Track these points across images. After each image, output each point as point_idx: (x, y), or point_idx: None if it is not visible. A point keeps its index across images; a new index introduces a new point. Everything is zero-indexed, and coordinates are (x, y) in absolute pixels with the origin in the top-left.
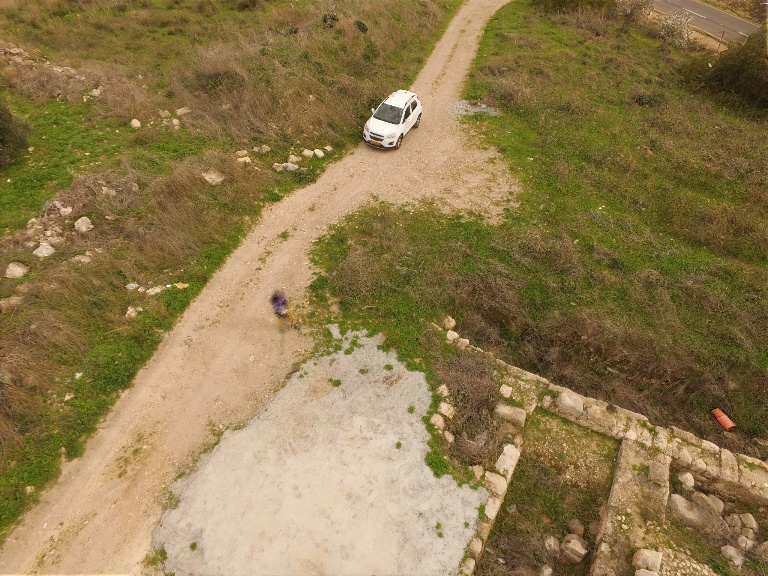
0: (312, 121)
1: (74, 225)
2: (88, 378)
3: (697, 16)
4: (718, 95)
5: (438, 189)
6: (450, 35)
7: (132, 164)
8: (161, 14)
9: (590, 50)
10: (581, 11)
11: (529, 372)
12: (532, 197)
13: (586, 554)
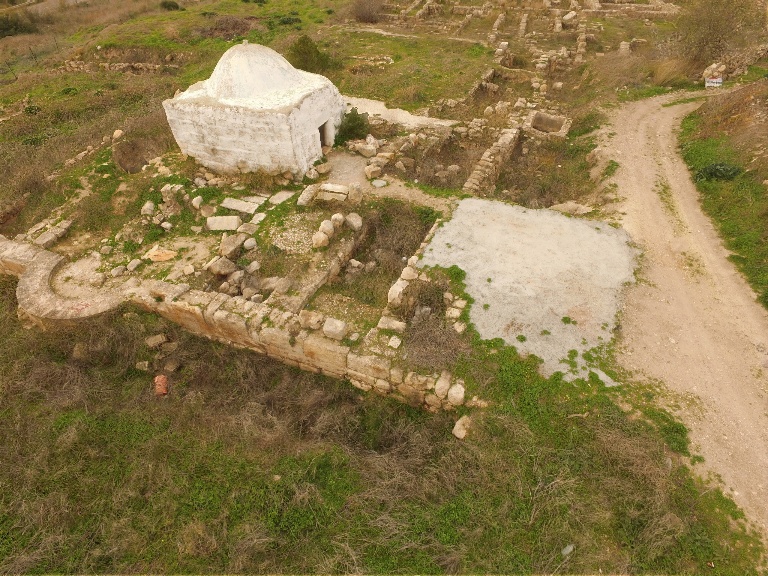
0: None
1: None
2: None
3: None
4: None
5: None
6: None
7: None
8: None
9: None
10: None
11: None
12: None
13: None
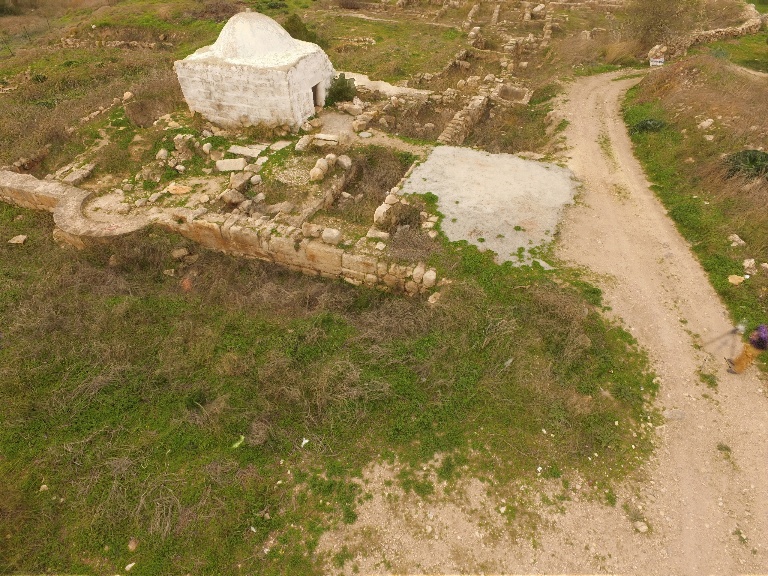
0: None
1: None
2: None
3: None
4: None
5: None
6: None
7: None
8: None
9: None
10: None
11: None
12: None
13: None
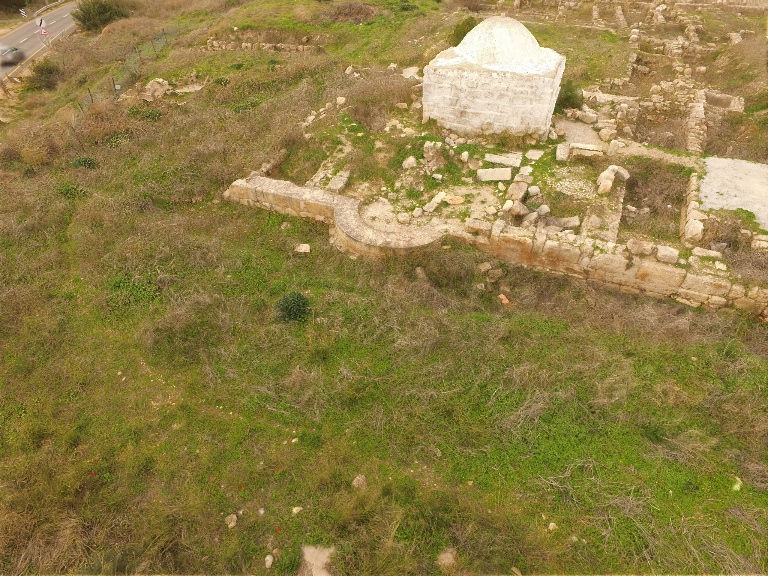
0: None
1: None
2: None
3: None
4: None
5: None
6: None
7: None
8: None
9: None
10: None
11: None
12: None
13: None
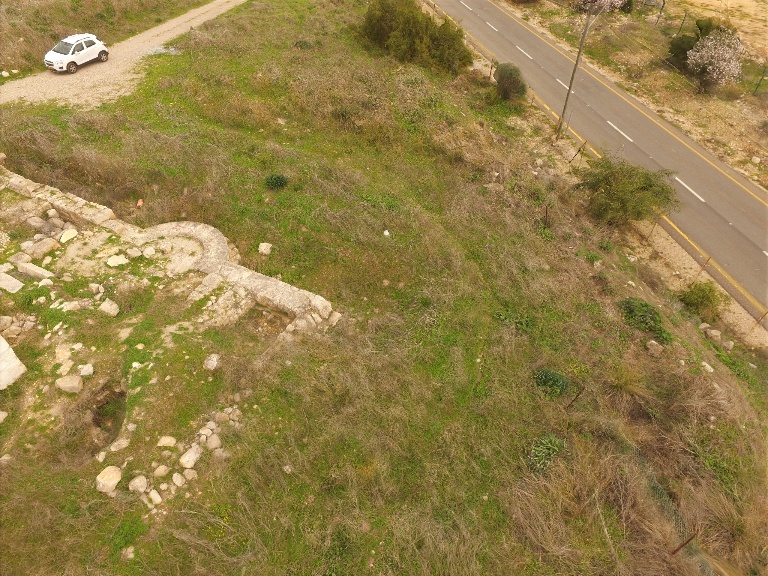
0: (8, 53)
1: None
2: None
3: None
4: None
5: (71, 94)
6: (213, 5)
7: None
8: None
9: None
10: None
11: None
12: (131, 98)
13: None
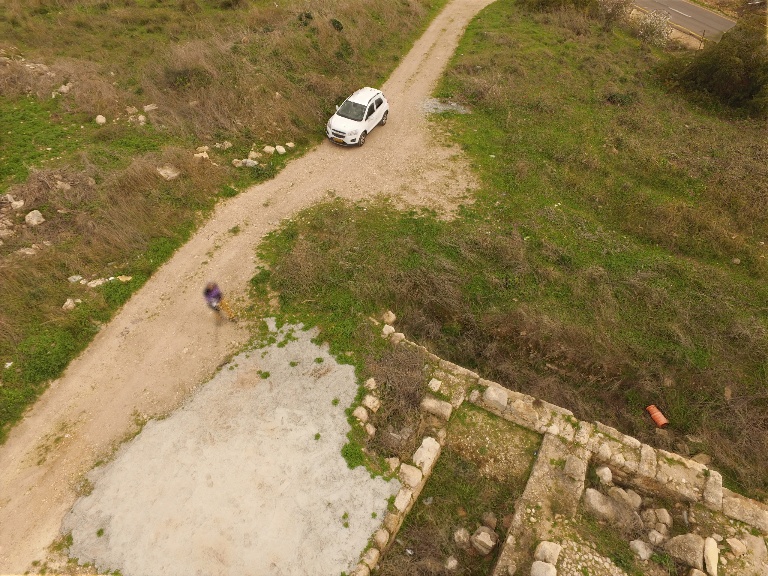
0: (275, 118)
1: (25, 218)
2: (18, 367)
3: (683, 15)
4: (692, 94)
5: (395, 186)
6: (430, 34)
7: (92, 159)
8: (141, 12)
9: (569, 49)
10: (564, 10)
11: (462, 367)
12: (489, 194)
13: (494, 546)
